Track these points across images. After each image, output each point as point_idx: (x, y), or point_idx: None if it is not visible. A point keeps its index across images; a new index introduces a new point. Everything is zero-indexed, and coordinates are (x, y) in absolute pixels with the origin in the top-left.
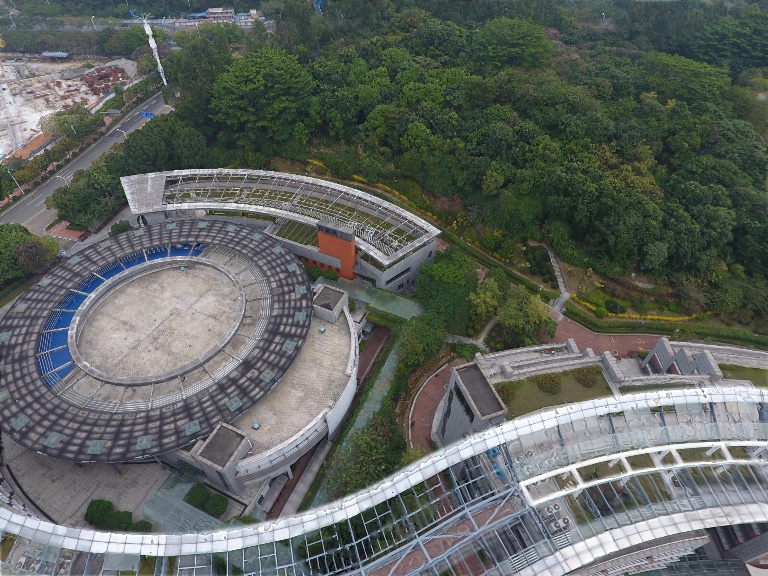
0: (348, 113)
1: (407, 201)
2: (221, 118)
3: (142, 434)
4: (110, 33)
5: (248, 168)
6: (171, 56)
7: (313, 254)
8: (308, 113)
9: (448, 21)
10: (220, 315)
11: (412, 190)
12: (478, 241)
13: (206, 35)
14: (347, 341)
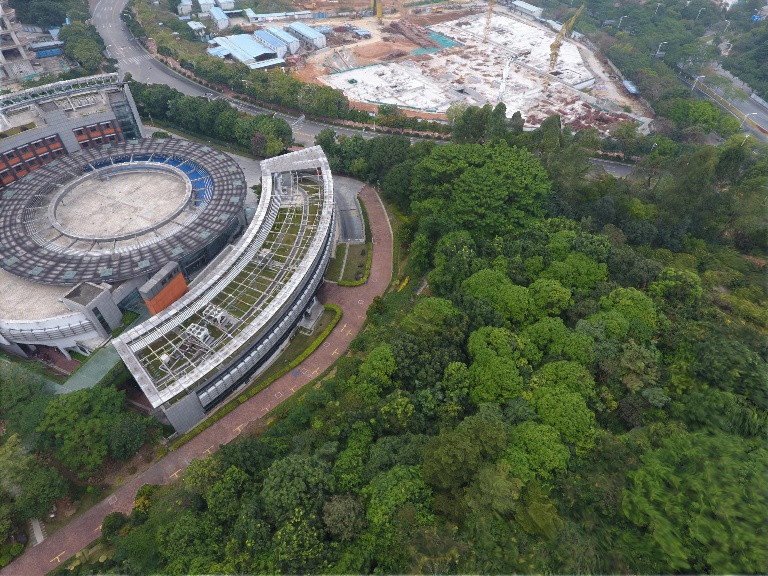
0: (445, 276)
1: None
2: None
3: (5, 209)
4: (680, 95)
5: None
6: (645, 138)
7: None
8: None
9: None
10: None
11: None
12: None
13: (762, 156)
14: None
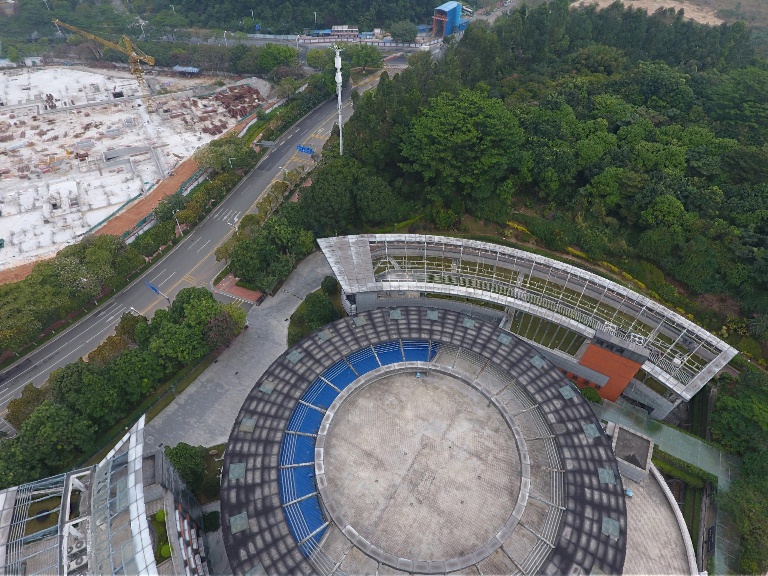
0: (567, 173)
1: (644, 288)
2: (417, 170)
3: None
4: (244, 50)
5: (433, 225)
6: (315, 80)
7: (567, 364)
8: (517, 169)
9: (664, 65)
10: (486, 454)
11: (650, 275)
12: (764, 359)
13: None
14: (668, 516)
